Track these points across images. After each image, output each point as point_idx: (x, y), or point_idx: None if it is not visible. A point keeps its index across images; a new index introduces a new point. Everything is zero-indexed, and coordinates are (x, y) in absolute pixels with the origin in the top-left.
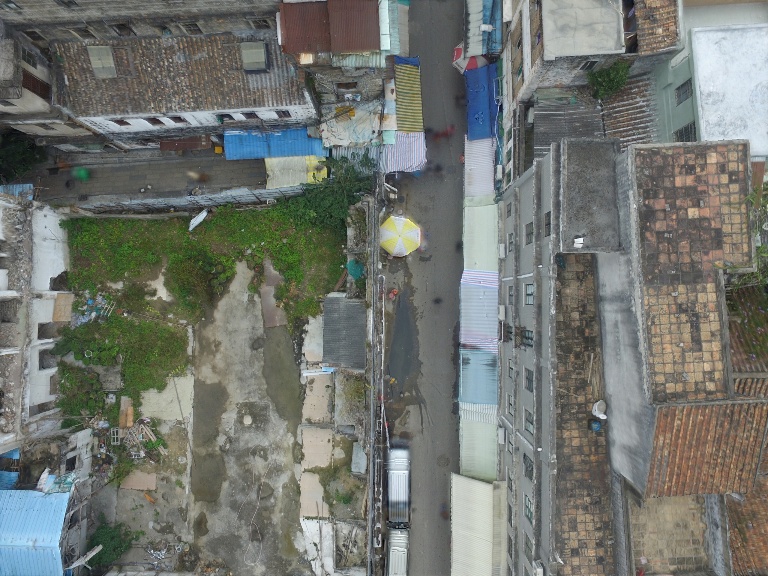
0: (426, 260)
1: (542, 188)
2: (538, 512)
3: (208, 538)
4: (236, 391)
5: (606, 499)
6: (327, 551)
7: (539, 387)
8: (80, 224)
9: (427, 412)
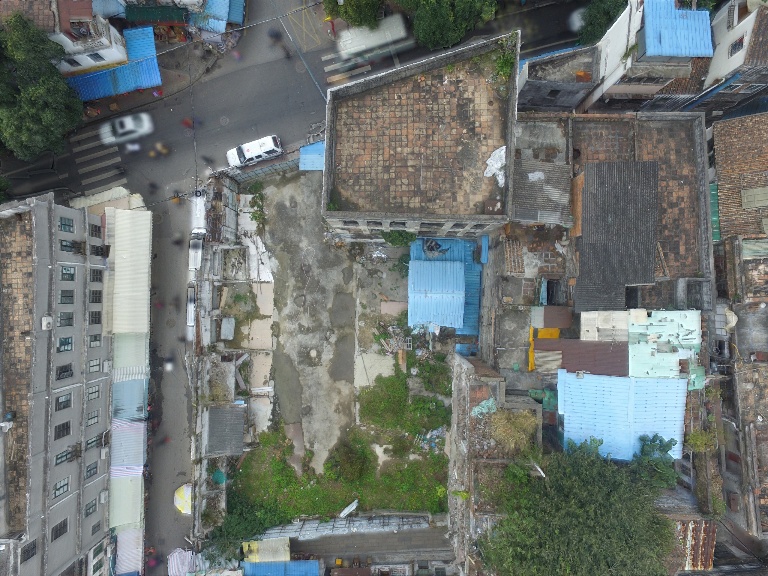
0: (181, 473)
1: (39, 570)
2: (49, 358)
3: (342, 266)
4: (322, 375)
5: (7, 367)
6: (254, 259)
7: (46, 438)
8: (439, 508)
9: (182, 359)
